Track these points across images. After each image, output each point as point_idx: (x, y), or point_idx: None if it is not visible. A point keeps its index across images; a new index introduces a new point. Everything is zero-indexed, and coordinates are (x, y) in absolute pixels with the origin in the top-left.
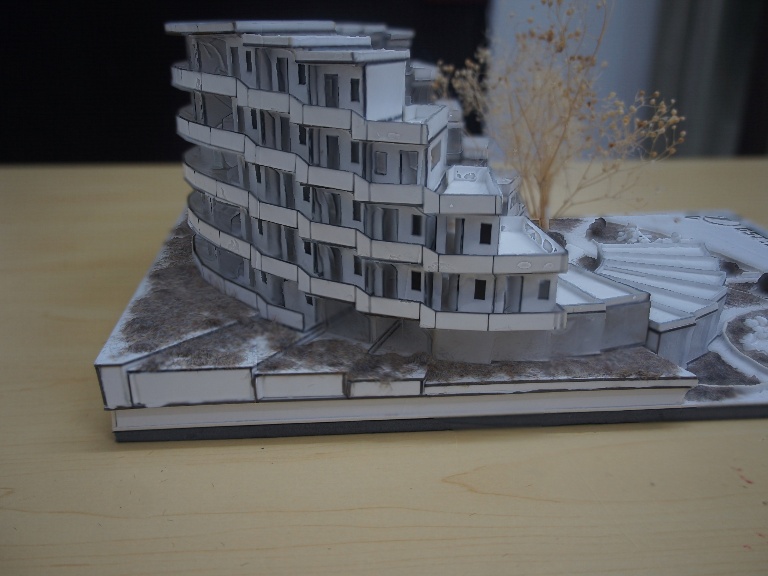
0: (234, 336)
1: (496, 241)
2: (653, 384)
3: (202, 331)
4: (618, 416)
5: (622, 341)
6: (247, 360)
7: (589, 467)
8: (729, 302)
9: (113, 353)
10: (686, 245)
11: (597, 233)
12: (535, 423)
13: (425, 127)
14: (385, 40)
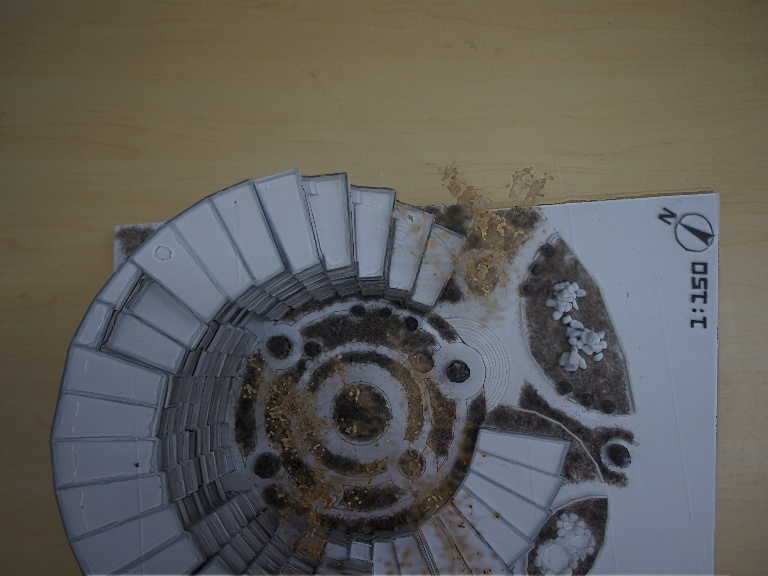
0: None
1: None
2: None
3: None
4: None
5: None
6: None
7: None
8: (572, 472)
9: None
10: (554, 442)
11: None
12: None
13: None
14: None
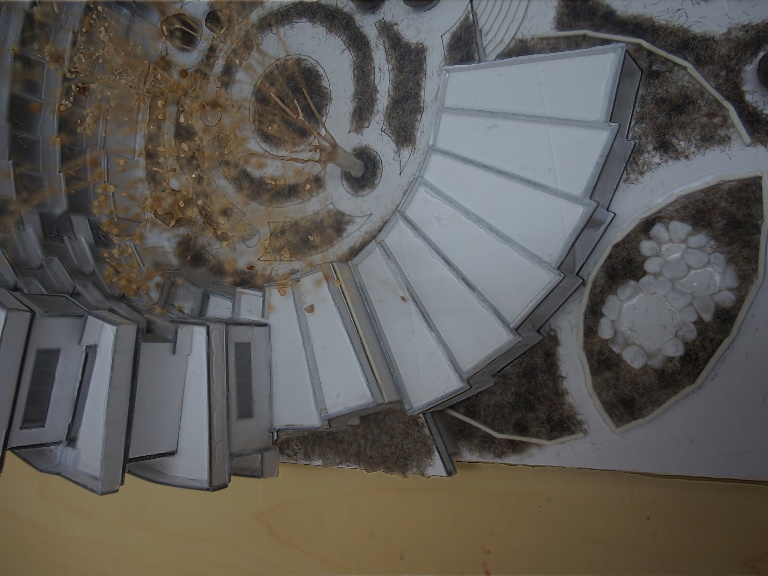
0: None
1: None
2: None
3: None
4: None
5: None
6: None
7: (357, 526)
8: (674, 136)
9: None
10: (590, 53)
11: None
12: None
13: None
14: None
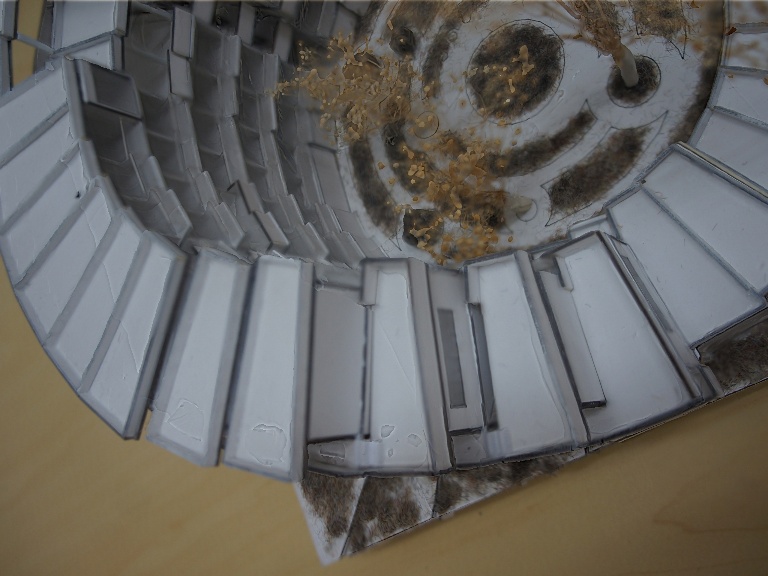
0: None
1: None
2: None
3: None
4: None
5: None
6: (421, 508)
7: None
8: None
9: (323, 542)
10: None
11: None
12: None
13: None
14: None
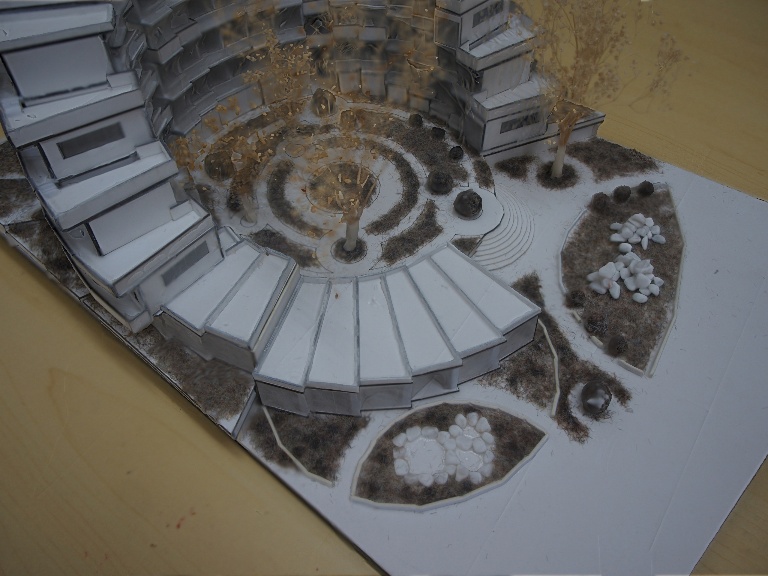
0: None
1: None
2: None
3: (21, 175)
4: None
5: (235, 363)
6: (8, 217)
7: (121, 430)
8: (521, 382)
9: None
10: (522, 299)
11: (596, 205)
12: None
13: None
14: None
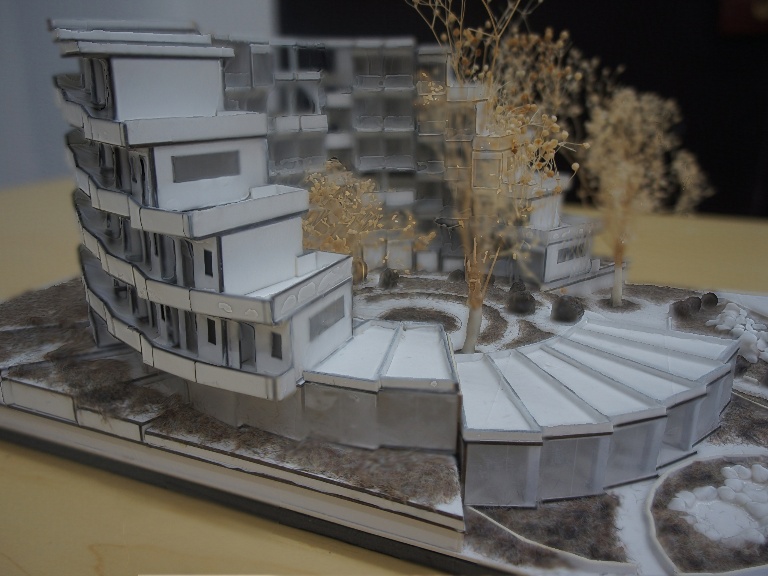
0: (37, 337)
1: (217, 273)
2: (402, 509)
3: (17, 327)
4: (371, 540)
5: (419, 441)
6: (7, 361)
7: None
8: (755, 435)
9: None
10: (711, 339)
11: (679, 310)
12: (273, 516)
13: (122, 126)
14: (415, 55)
